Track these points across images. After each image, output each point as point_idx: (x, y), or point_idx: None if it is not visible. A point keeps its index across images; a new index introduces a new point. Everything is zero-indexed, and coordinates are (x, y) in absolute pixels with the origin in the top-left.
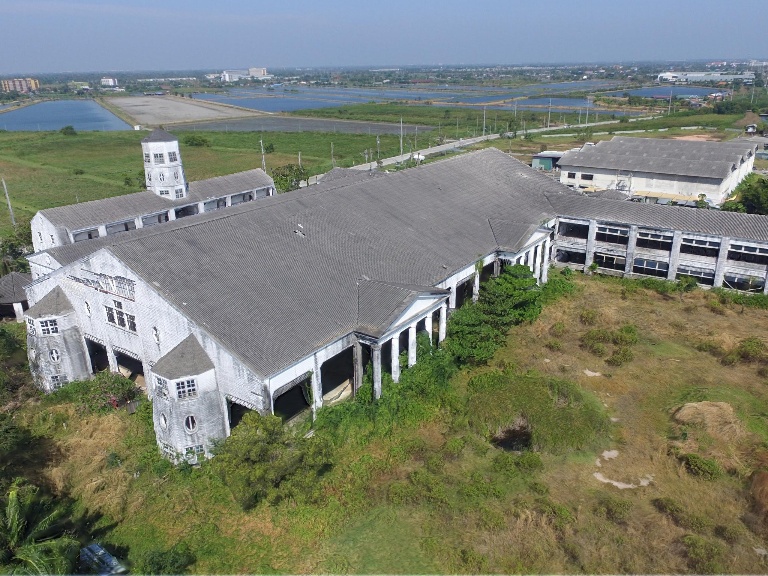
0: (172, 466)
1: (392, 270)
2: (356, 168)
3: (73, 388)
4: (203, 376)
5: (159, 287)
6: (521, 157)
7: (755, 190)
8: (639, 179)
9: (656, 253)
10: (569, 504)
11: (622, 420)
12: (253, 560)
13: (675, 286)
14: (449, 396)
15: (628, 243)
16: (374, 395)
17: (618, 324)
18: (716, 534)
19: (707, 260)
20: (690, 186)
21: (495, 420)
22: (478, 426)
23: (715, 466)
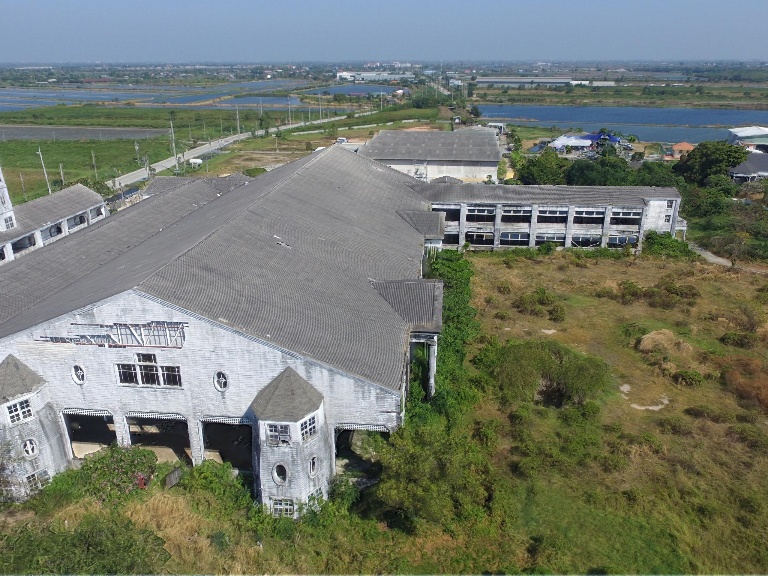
0: (293, 522)
1: (382, 269)
2: (126, 178)
3: (66, 482)
4: (320, 410)
5: (229, 323)
6: (292, 155)
7: (528, 168)
8: (432, 167)
9: (518, 226)
10: (641, 433)
11: (607, 361)
12: (470, 573)
13: (538, 251)
14: (477, 376)
15: (495, 220)
16: (430, 391)
17: (527, 289)
18: (739, 421)
19: (558, 226)
20: (474, 169)
21: (531, 386)
22: (523, 394)
23: (700, 375)
